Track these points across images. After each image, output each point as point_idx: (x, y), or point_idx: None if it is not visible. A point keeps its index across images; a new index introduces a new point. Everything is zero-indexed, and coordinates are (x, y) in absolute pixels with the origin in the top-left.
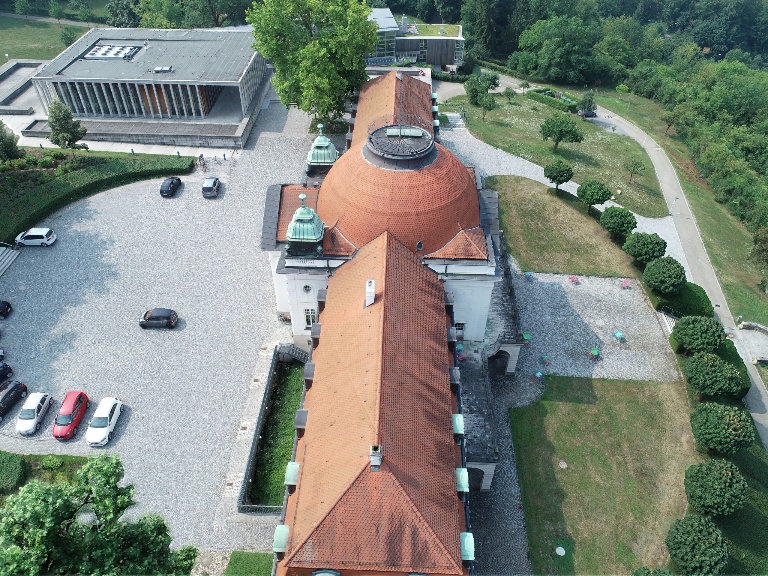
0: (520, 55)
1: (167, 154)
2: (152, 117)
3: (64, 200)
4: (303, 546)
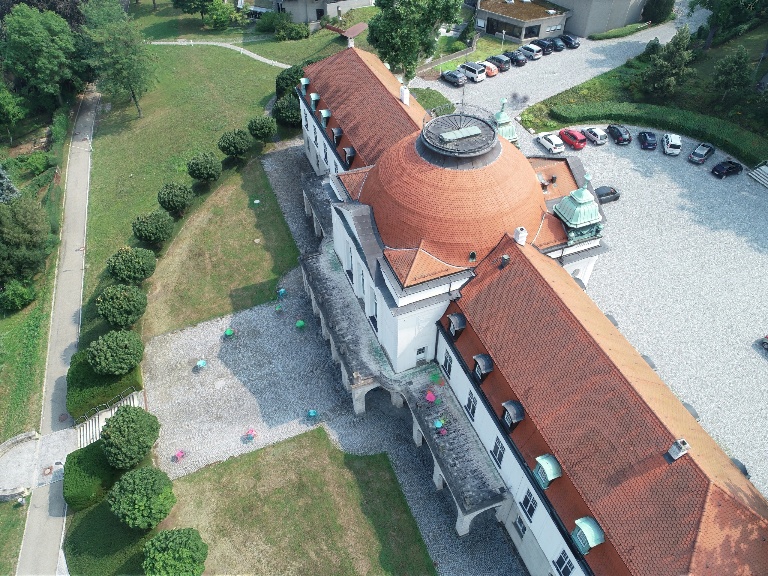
0: None
1: None
2: None
3: None
4: None
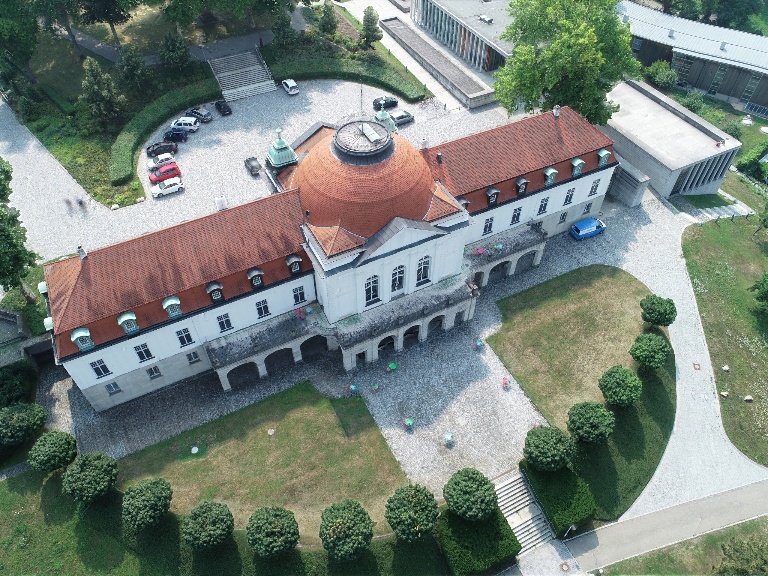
0: None
1: (423, 83)
2: (456, 52)
3: (333, 75)
4: (50, 265)
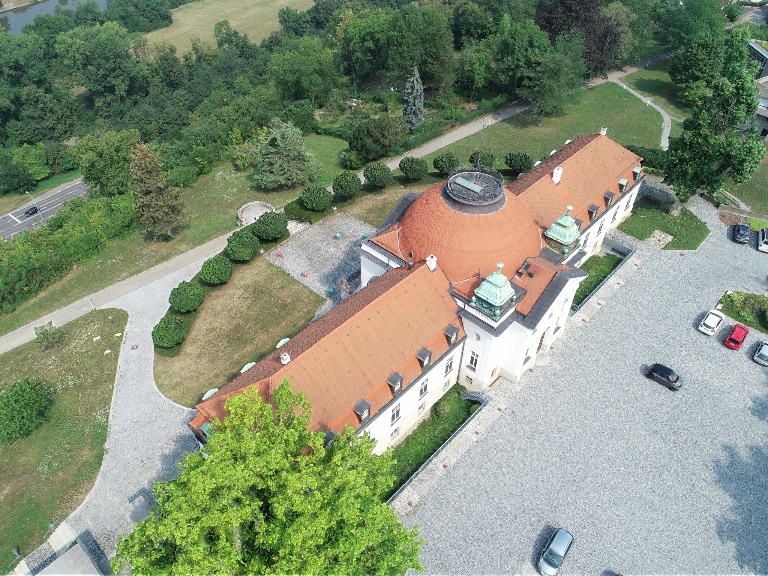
0: None
1: None
2: None
3: None
4: None
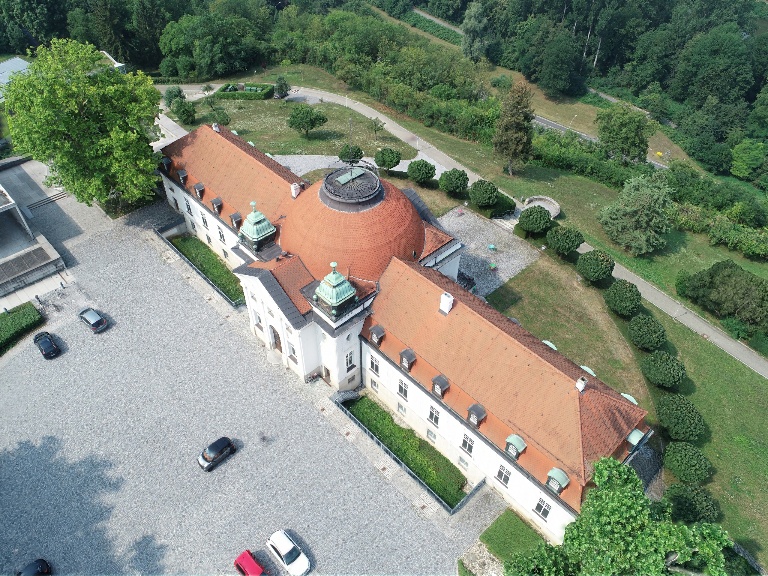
0: (178, 62)
1: None
2: None
3: None
4: (584, 466)
